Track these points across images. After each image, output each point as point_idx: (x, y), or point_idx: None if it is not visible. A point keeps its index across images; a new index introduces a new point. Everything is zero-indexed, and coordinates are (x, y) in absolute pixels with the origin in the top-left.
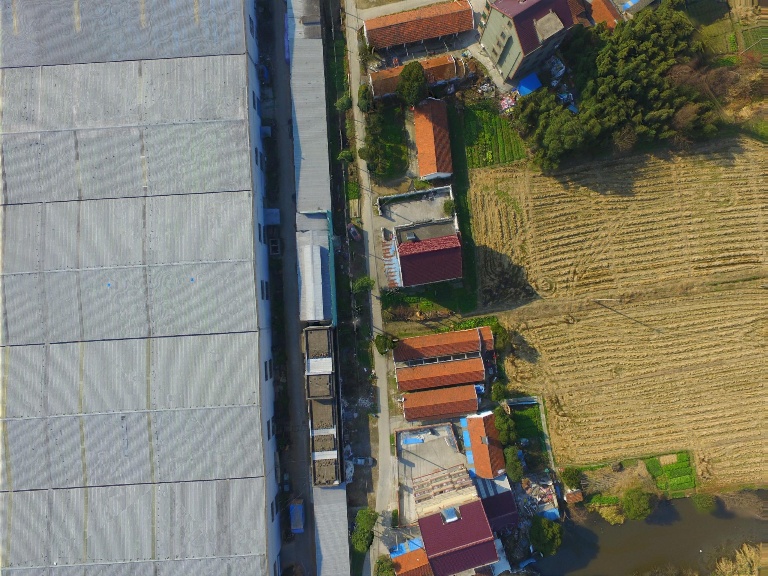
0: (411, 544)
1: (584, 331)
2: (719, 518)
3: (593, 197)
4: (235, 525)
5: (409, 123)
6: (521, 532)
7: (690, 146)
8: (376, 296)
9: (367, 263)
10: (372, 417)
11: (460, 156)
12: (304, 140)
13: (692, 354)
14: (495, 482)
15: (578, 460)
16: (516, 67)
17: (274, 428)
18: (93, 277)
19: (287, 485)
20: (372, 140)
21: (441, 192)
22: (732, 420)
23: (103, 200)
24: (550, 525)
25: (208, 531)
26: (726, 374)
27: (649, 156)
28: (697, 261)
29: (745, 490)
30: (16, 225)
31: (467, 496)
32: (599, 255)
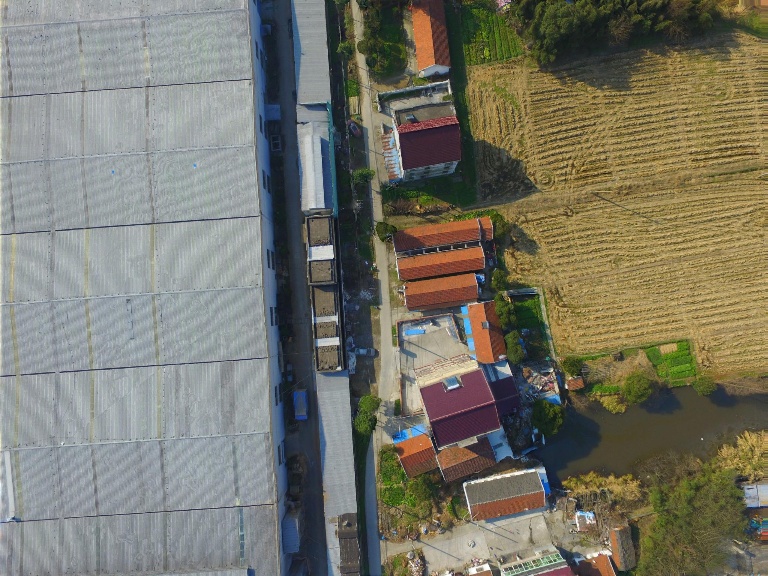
0: (414, 430)
1: (583, 223)
2: (720, 406)
3: (590, 92)
4: (239, 404)
5: (407, 22)
6: (523, 420)
7: (686, 40)
8: (376, 191)
9: (367, 159)
10: (374, 309)
11: (458, 54)
12: (304, 36)
13: (691, 244)
14: (496, 368)
15: (579, 350)
16: None
17: (277, 319)
18: (97, 164)
19: (290, 375)
20: (371, 33)
21: (439, 88)
22: (731, 309)
23: (106, 91)
24: (551, 406)
25: (213, 411)
26: (725, 264)
27: (645, 51)
28: (694, 153)
29: (745, 378)
30: (21, 116)
31: (468, 369)
32: (597, 148)
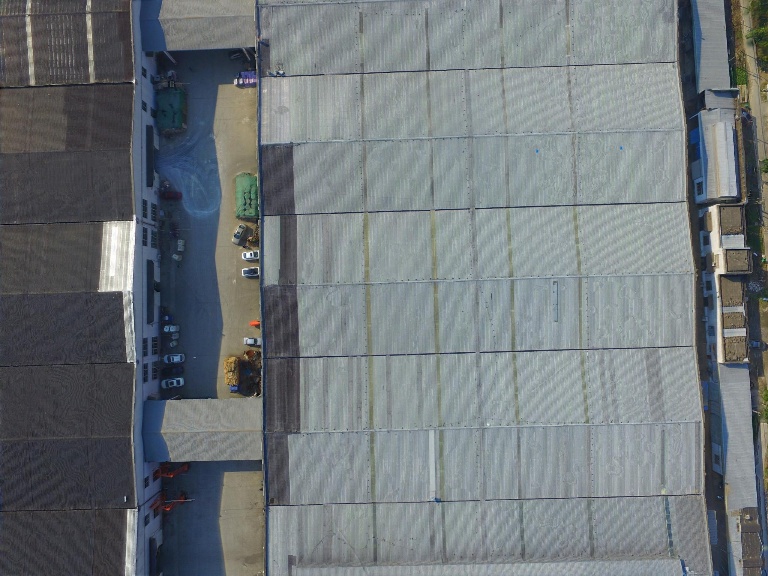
0: None
1: None
2: None
3: None
4: (668, 392)
5: None
6: None
7: None
8: (765, 181)
9: None
10: (762, 302)
11: None
12: (704, 21)
13: None
14: None
15: None
16: None
17: None
18: (522, 143)
19: None
20: None
21: None
22: None
23: (526, 68)
24: None
25: (640, 397)
26: None
27: None
28: None
29: None
30: (440, 91)
31: None
32: None
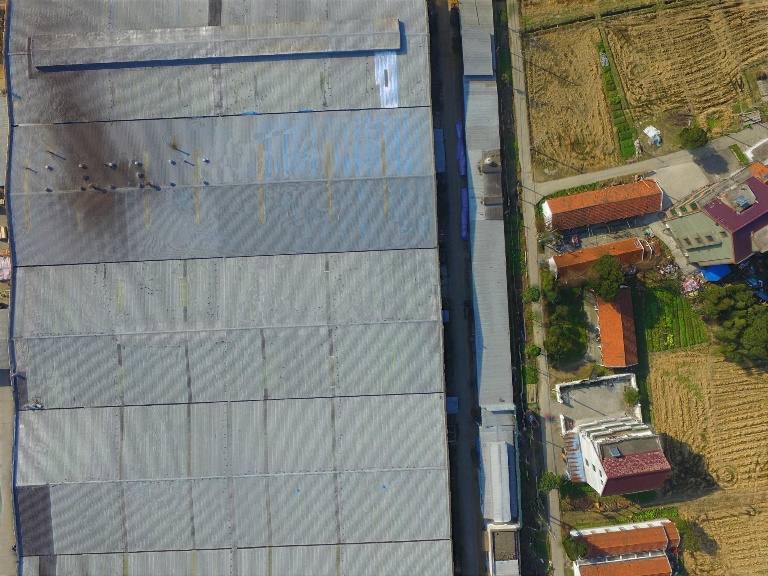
0: None
1: (766, 523)
2: None
3: None
4: None
5: (588, 304)
6: None
7: None
8: None
9: (544, 450)
10: None
11: (640, 339)
12: (486, 328)
13: None
14: None
15: None
16: (715, 263)
17: None
18: (283, 483)
19: None
20: (560, 333)
21: (622, 379)
22: None
23: (290, 400)
24: None
25: None
26: None
27: None
28: None
29: None
30: (201, 425)
31: None
32: None
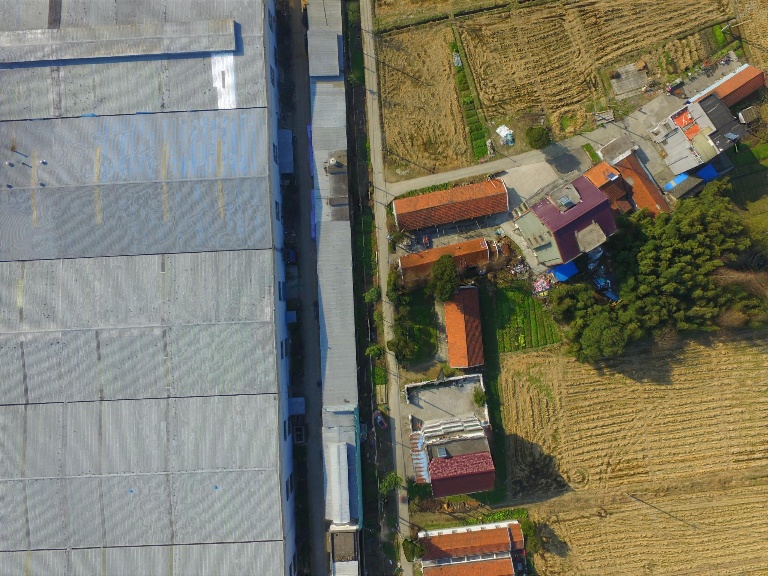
0: None
1: (617, 525)
2: None
3: (629, 385)
4: None
5: (439, 304)
6: None
7: (732, 333)
8: (403, 486)
9: (394, 451)
10: None
11: (491, 340)
12: (331, 329)
13: (729, 551)
14: None
15: None
16: (553, 263)
17: None
18: (116, 483)
19: None
20: (401, 333)
21: (471, 379)
22: None
23: (125, 401)
24: None
25: None
26: (764, 572)
27: (689, 342)
28: (736, 454)
29: None
30: (37, 426)
31: None
32: (634, 446)
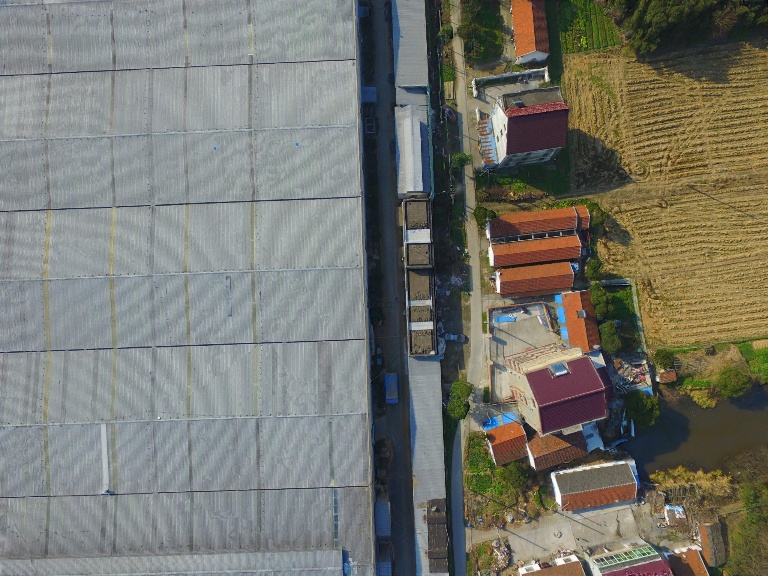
0: (504, 418)
1: (677, 215)
2: None
3: (687, 83)
4: (337, 385)
5: (504, 8)
6: (613, 412)
7: None
8: (470, 176)
9: (461, 144)
10: (464, 295)
11: (554, 41)
12: (403, 19)
13: None
14: None
15: (670, 343)
16: None
17: (368, 302)
18: (200, 140)
19: (380, 359)
20: (472, 17)
21: (536, 75)
22: None
23: (209, 67)
24: (648, 397)
25: (310, 390)
26: None
27: (744, 44)
28: None
29: None
30: (124, 90)
31: (572, 356)
32: (693, 141)
